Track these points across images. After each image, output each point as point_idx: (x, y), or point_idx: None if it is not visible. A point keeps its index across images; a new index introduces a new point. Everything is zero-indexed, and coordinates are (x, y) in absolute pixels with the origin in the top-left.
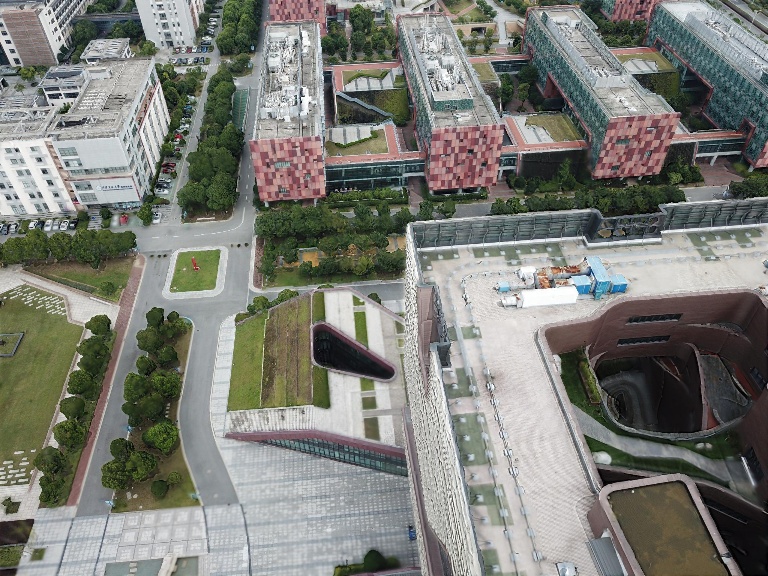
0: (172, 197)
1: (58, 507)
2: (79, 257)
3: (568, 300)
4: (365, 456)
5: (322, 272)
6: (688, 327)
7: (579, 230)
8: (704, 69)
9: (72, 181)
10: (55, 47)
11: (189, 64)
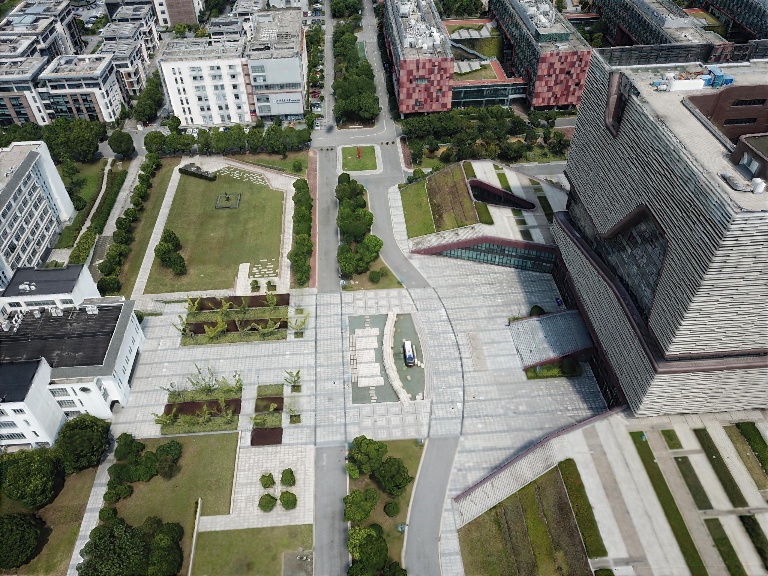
0: (325, 113)
1: (304, 288)
2: (270, 147)
3: (698, 87)
4: (520, 257)
5: (461, 156)
6: None
7: (697, 57)
8: (748, 20)
9: (255, 95)
10: (196, 10)
11: (308, 24)
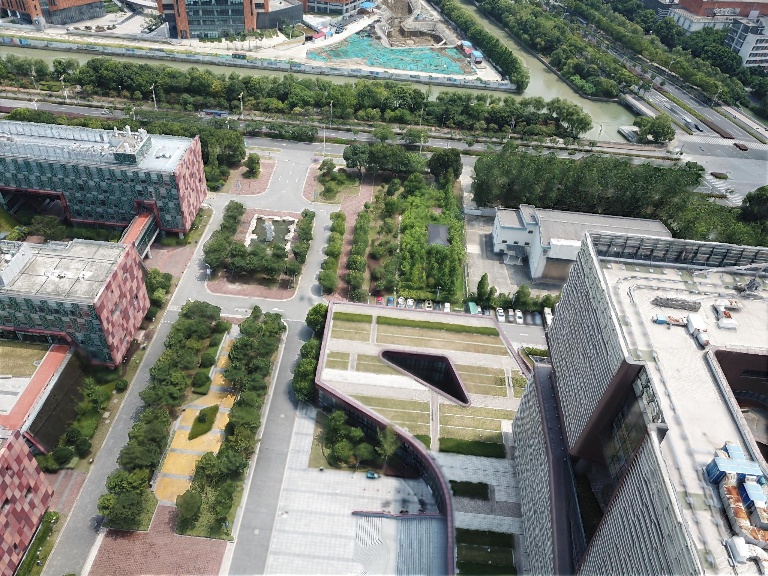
0: None
1: None
2: None
3: None
4: None
5: None
6: None
7: None
8: (29, 181)
9: None
10: None
11: None
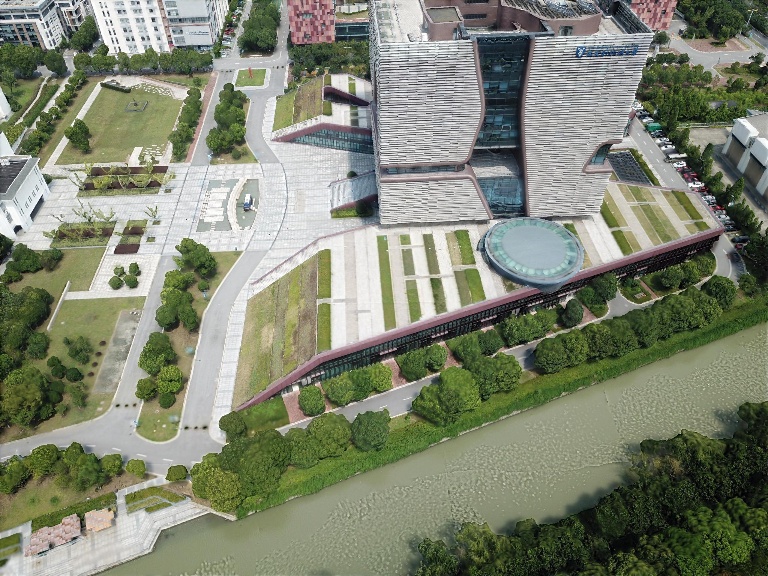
0: (233, 46)
1: (180, 163)
2: (177, 68)
3: None
4: (351, 140)
5: None
6: (493, 8)
7: None
8: None
9: (171, 27)
10: None
11: None
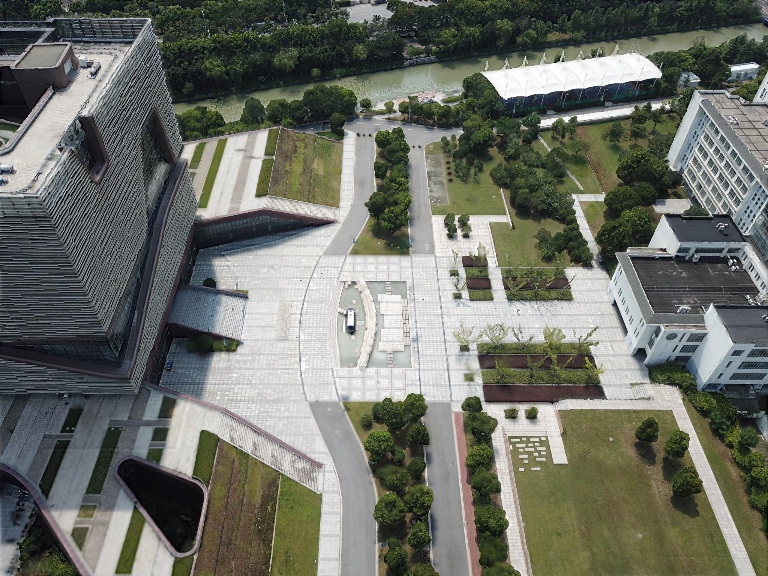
0: None
1: None
2: None
3: None
4: None
5: None
6: None
7: None
8: None
9: None
10: None
11: None
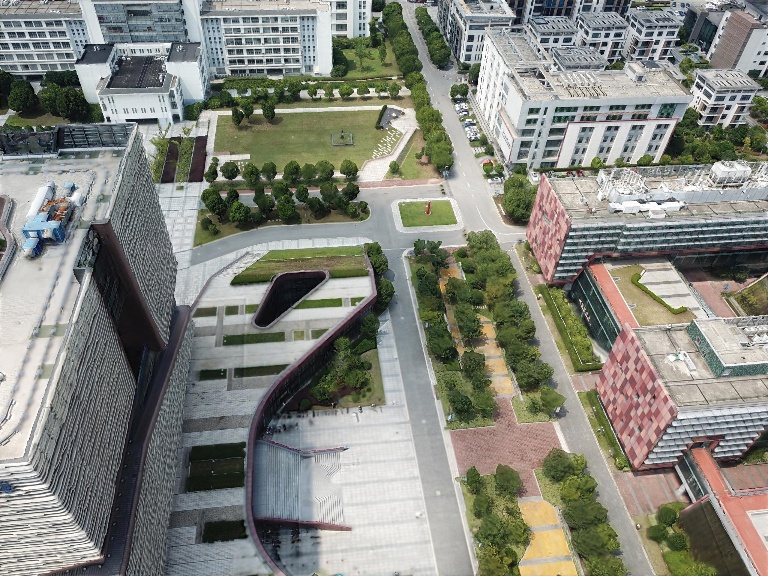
0: None
1: None
2: None
3: None
4: None
5: None
6: None
7: None
8: None
9: None
10: (746, 65)
11: None
